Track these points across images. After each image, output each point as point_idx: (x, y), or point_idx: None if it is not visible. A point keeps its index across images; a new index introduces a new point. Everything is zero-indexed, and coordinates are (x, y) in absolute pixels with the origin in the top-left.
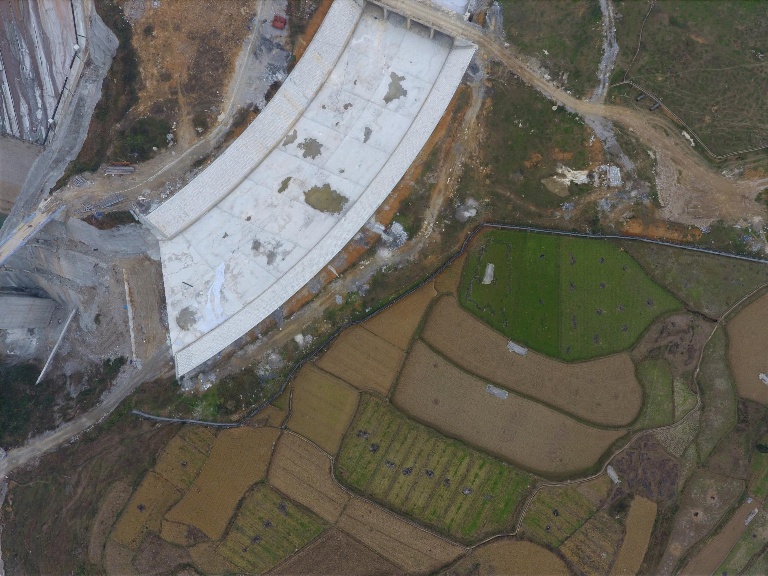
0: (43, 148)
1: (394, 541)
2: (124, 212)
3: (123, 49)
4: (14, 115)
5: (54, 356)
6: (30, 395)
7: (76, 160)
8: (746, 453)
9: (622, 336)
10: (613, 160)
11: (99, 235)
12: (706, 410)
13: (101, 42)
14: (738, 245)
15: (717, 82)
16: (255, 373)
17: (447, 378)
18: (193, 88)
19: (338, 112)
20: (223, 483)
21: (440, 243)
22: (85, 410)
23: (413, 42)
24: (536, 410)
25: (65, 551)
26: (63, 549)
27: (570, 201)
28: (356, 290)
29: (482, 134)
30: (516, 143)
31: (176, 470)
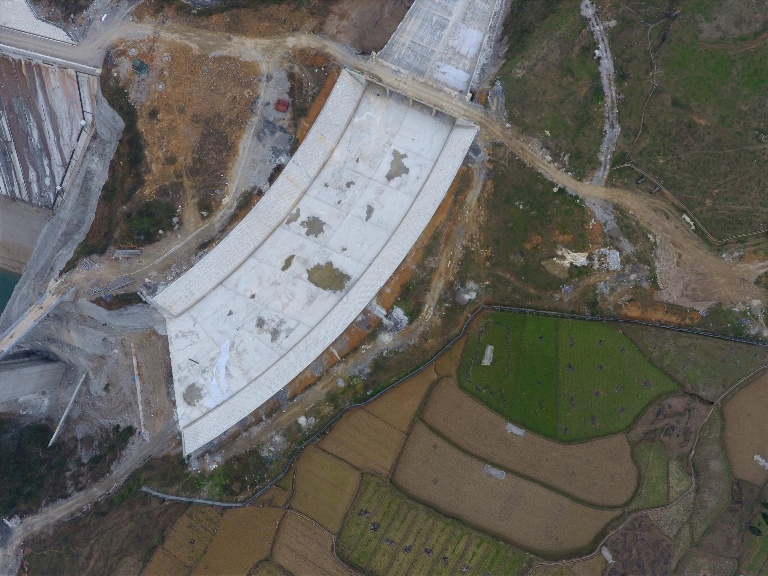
0: (52, 212)
1: None
2: (131, 294)
3: (129, 132)
4: (23, 181)
5: (65, 419)
6: (43, 458)
7: (84, 242)
8: (739, 533)
9: (619, 417)
10: (613, 243)
11: (107, 314)
12: (700, 491)
13: (107, 121)
14: (736, 328)
15: (719, 165)
16: (259, 454)
17: (446, 458)
18: (198, 171)
19: (341, 190)
20: (229, 560)
21: (440, 326)
22: (96, 480)
23: (415, 119)
24: (533, 490)
25: None
26: None
27: (569, 283)
28: (358, 373)
29: (483, 217)
30: (517, 225)
31: (184, 547)
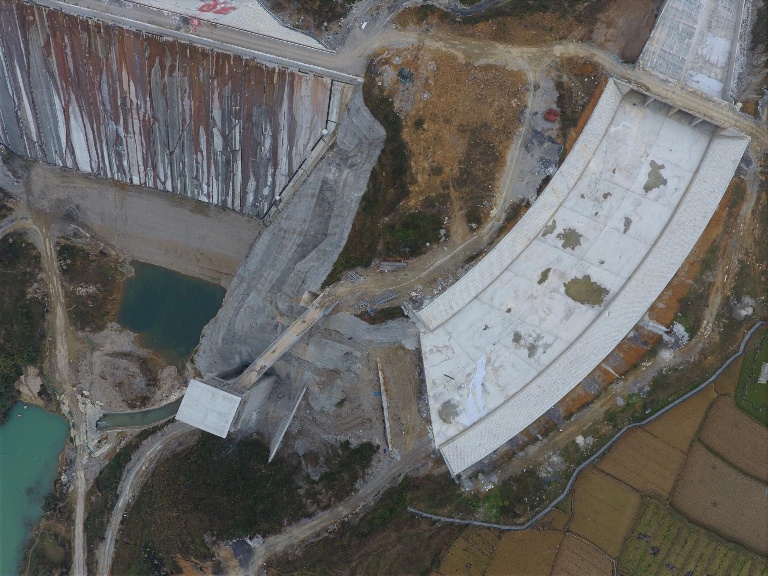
0: (262, 222)
1: None
2: (396, 308)
3: (392, 142)
4: (239, 191)
5: (284, 434)
6: (266, 475)
7: (346, 254)
8: None
9: None
10: None
11: (366, 329)
12: None
13: (359, 130)
14: None
15: None
16: (537, 475)
17: (725, 480)
18: (465, 182)
19: (597, 202)
20: None
21: (719, 343)
22: (341, 499)
23: (673, 129)
24: None
25: None
26: None
27: None
28: (637, 391)
29: (758, 230)
30: None
31: (460, 571)
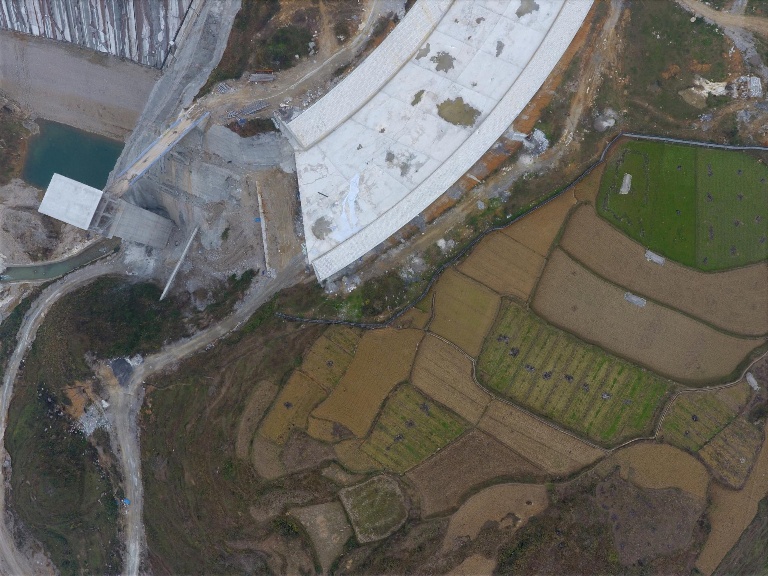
0: (160, 72)
1: (535, 442)
2: (266, 119)
3: None
4: (135, 38)
5: (176, 274)
6: (156, 310)
7: (218, 68)
8: None
9: (759, 247)
10: (753, 71)
11: (239, 144)
12: None
13: None
14: None
15: None
16: (399, 276)
17: (585, 285)
18: None
19: (471, 26)
20: (368, 382)
21: (580, 152)
22: (219, 319)
23: None
24: (674, 318)
25: (211, 448)
26: (208, 446)
27: (708, 112)
28: (498, 196)
29: (621, 45)
30: (654, 54)
31: (322, 369)
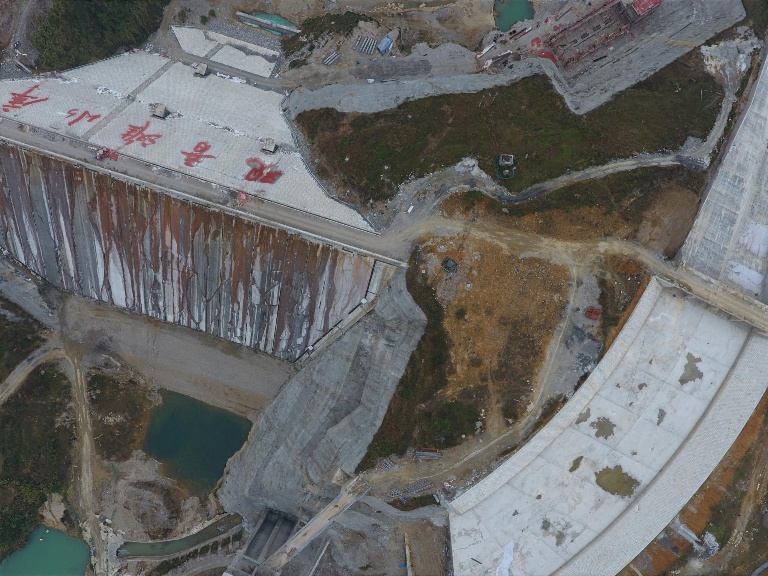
0: (293, 366)
1: None
2: (429, 497)
3: (433, 329)
4: (273, 338)
5: None
6: None
7: (382, 440)
8: None
9: None
10: None
11: (397, 512)
12: None
13: (399, 308)
14: None
15: None
16: None
17: None
18: (503, 375)
19: (632, 392)
20: None
21: (748, 552)
22: None
23: (711, 323)
24: None
25: None
26: None
27: None
28: None
29: None
30: None
31: None
